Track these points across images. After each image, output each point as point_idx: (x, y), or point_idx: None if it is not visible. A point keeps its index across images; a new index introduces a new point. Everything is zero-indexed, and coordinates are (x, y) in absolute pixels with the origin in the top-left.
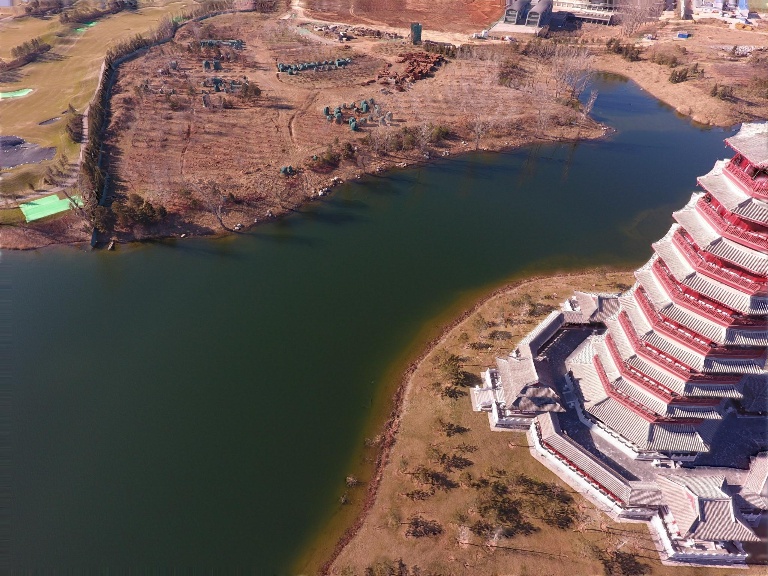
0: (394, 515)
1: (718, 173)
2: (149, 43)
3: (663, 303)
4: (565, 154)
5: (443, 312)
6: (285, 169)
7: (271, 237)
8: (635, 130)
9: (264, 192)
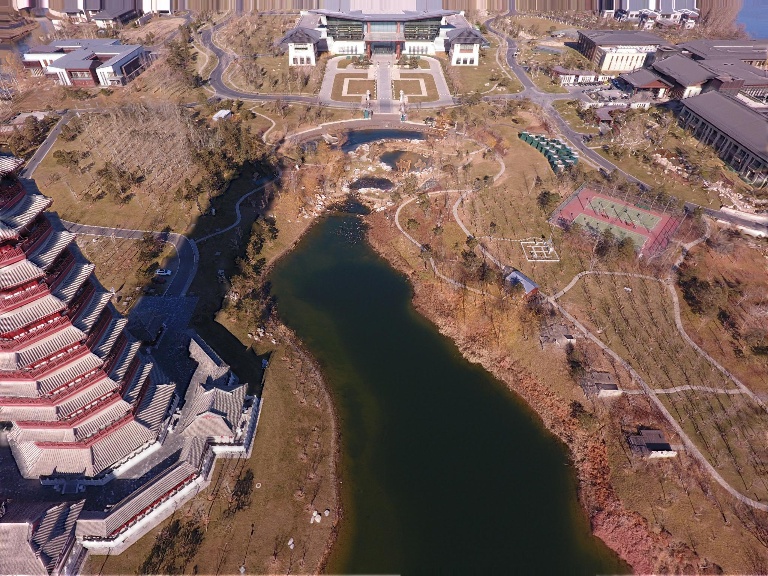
0: None
1: None
2: None
3: (11, 361)
4: None
5: None
6: None
7: None
8: None
9: None
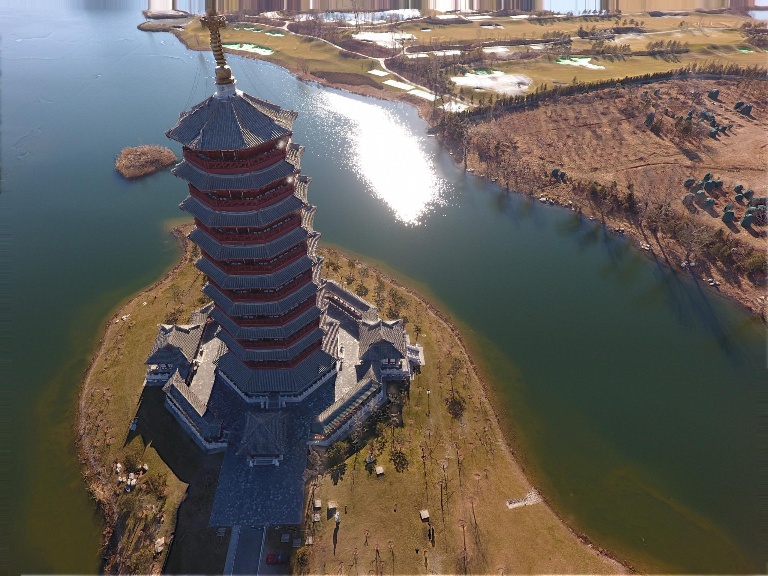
0: None
1: None
2: (753, 75)
3: None
4: None
5: (396, 270)
6: (555, 170)
7: (465, 185)
8: None
9: (519, 170)
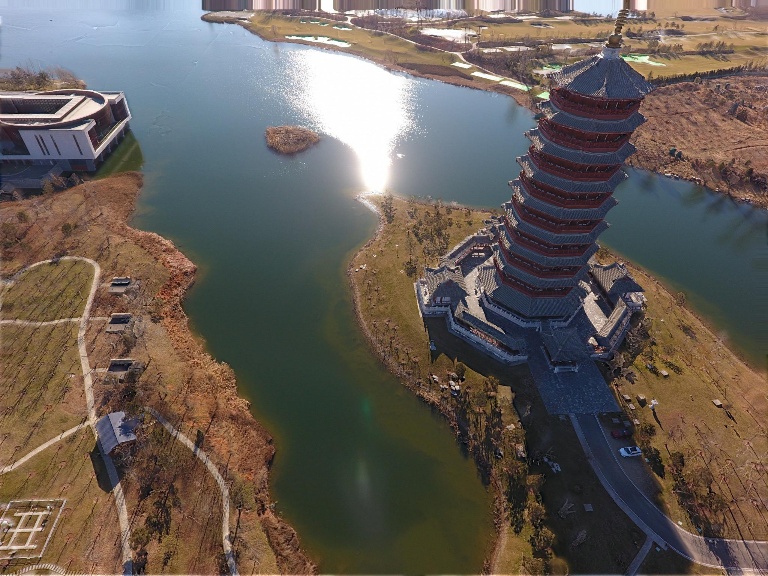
0: (412, 196)
1: None
2: None
3: None
4: None
5: None
6: (673, 150)
7: None
8: None
9: None
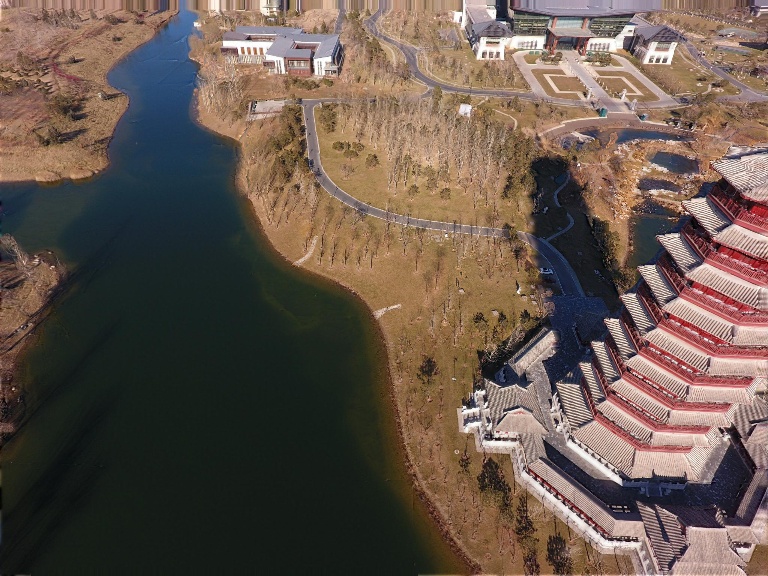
0: None
1: (764, 248)
2: None
3: (761, 368)
4: (51, 328)
5: None
6: None
7: None
8: (60, 233)
9: None
